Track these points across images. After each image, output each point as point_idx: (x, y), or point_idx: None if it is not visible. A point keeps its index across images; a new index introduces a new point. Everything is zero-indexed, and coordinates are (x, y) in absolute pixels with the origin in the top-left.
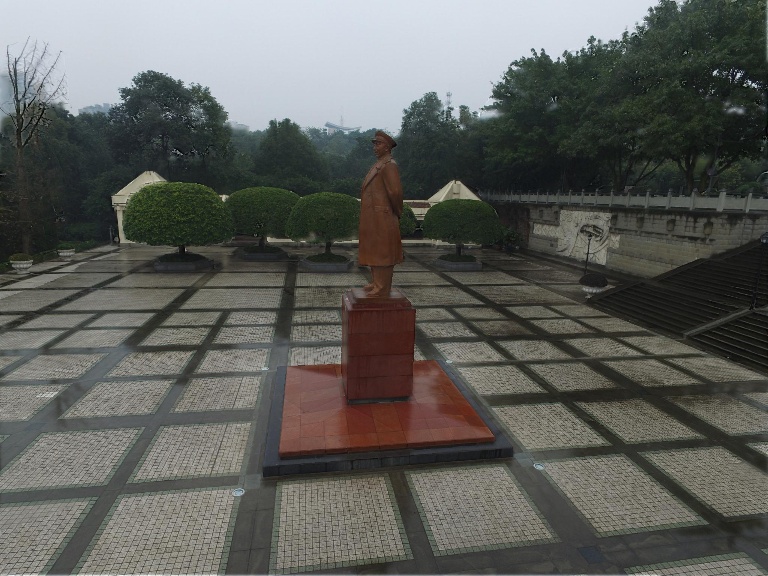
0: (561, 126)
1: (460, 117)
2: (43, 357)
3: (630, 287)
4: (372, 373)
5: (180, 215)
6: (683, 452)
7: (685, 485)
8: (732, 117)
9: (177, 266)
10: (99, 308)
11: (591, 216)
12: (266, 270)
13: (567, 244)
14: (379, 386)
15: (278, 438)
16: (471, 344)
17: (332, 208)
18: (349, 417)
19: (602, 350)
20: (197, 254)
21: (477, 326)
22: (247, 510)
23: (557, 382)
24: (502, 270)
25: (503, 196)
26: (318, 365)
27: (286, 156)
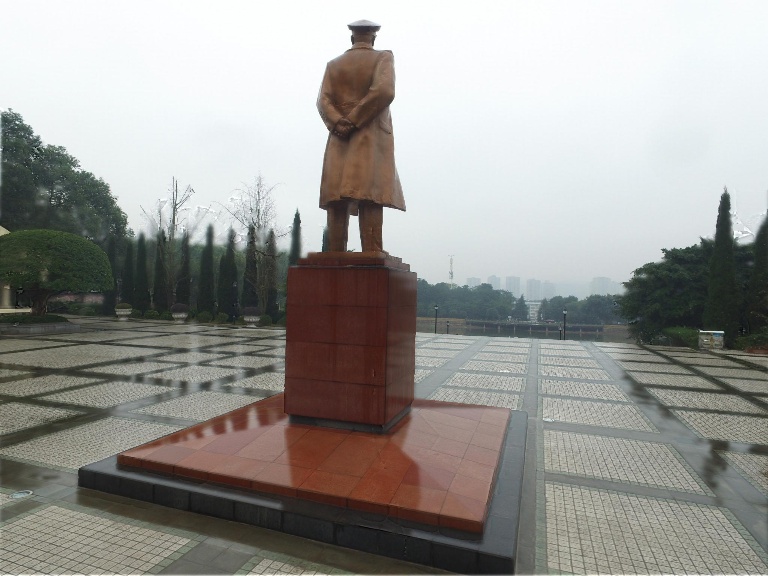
0: None
1: None
2: (598, 370)
3: None
4: None
5: None
6: None
7: None
8: None
9: None
10: None
11: None
12: None
13: None
14: None
15: None
16: None
17: None
18: None
19: None
20: None
21: None
22: (265, 391)
23: None
24: None
25: None
26: (503, 418)
27: None
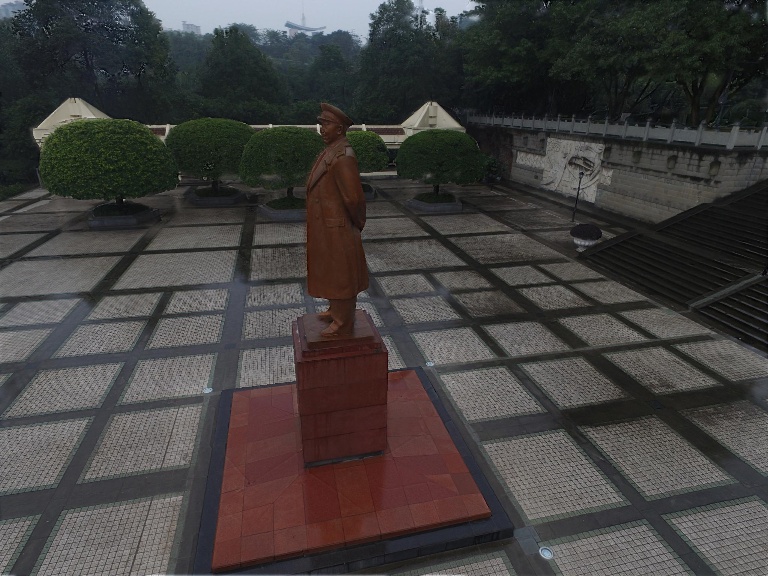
0: (554, 40)
1: (436, 23)
2: None
3: (626, 240)
4: (334, 431)
5: (108, 162)
6: (714, 511)
7: (725, 575)
8: (759, 34)
9: (115, 221)
10: (11, 293)
11: (582, 147)
12: (220, 221)
13: (553, 177)
14: (344, 444)
15: (214, 530)
16: (454, 332)
17: (291, 147)
18: (306, 492)
19: (602, 334)
20: (138, 204)
21: (460, 302)
22: None
23: (556, 393)
24: (484, 211)
25: (484, 118)
26: (271, 388)
27: (238, 74)
